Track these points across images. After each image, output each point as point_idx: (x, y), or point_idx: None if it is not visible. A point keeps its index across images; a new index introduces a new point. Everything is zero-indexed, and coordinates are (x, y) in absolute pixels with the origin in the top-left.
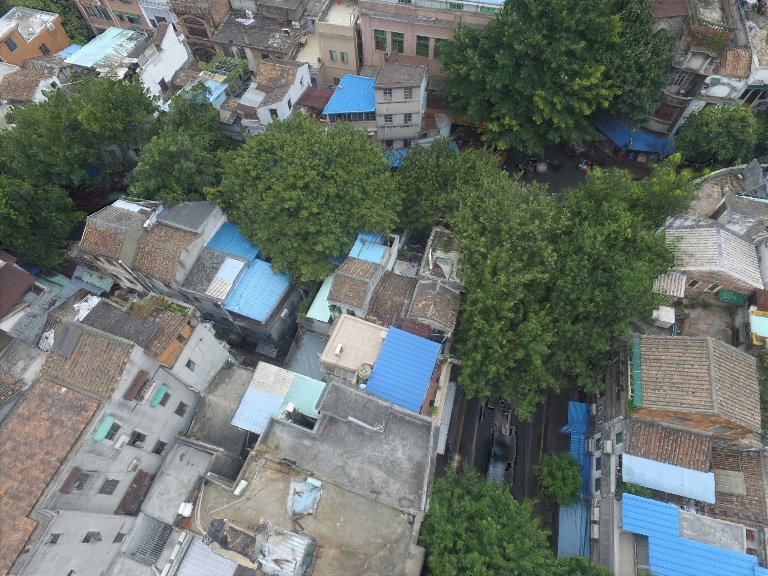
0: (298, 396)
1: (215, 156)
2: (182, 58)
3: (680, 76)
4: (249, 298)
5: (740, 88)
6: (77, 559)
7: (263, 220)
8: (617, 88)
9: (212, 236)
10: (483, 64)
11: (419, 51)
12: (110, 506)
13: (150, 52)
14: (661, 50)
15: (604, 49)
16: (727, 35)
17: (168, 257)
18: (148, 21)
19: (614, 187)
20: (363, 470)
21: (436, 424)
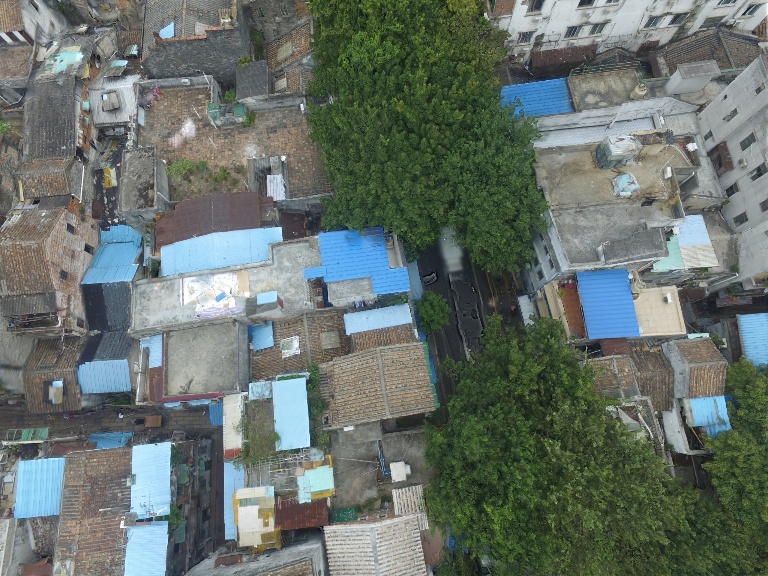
0: (671, 252)
1: None
2: None
3: None
4: None
5: None
6: (729, 103)
7: None
8: None
9: None
10: None
11: None
12: (734, 140)
13: None
14: None
15: None
16: None
17: None
18: None
19: None
20: (595, 221)
21: (550, 292)
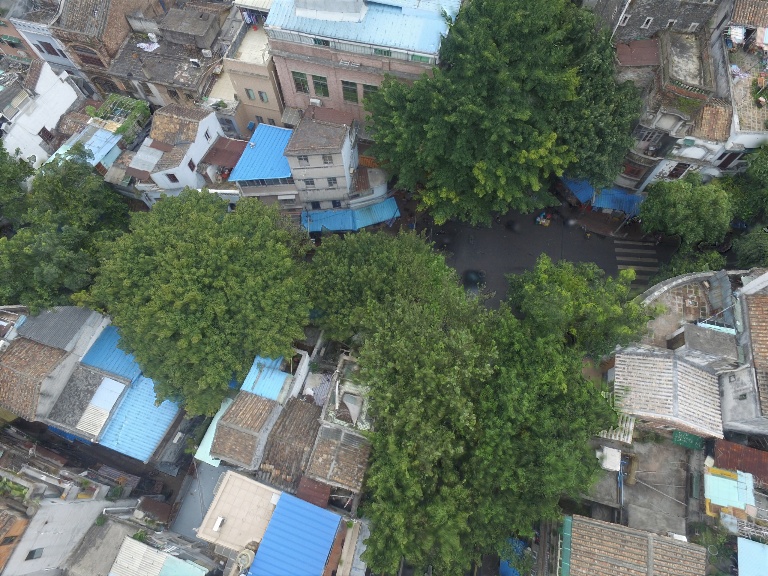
0: None
1: (98, 238)
2: (69, 99)
3: (649, 132)
4: (130, 429)
5: (717, 151)
6: None
7: (142, 339)
8: (574, 153)
9: (90, 346)
10: (412, 131)
11: (347, 96)
12: None
13: (20, 101)
14: (626, 109)
15: (560, 105)
16: (703, 97)
17: (26, 388)
18: (32, 46)
19: (552, 317)
20: None
21: None
